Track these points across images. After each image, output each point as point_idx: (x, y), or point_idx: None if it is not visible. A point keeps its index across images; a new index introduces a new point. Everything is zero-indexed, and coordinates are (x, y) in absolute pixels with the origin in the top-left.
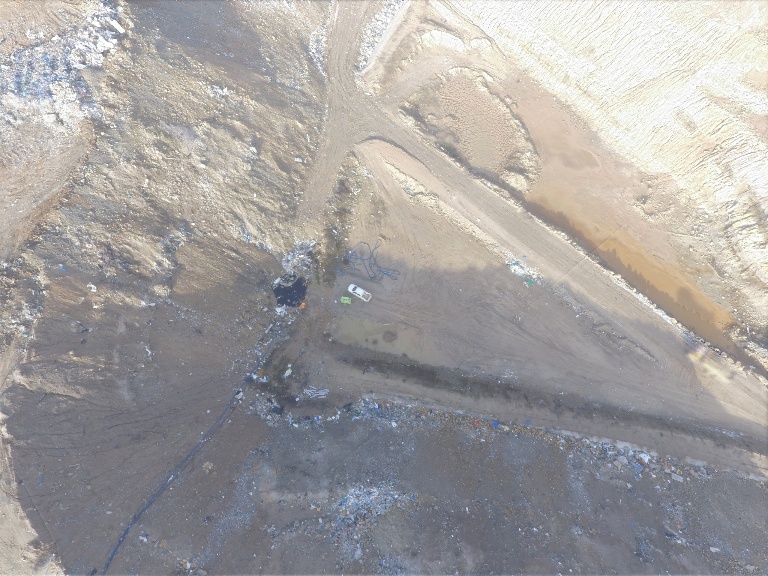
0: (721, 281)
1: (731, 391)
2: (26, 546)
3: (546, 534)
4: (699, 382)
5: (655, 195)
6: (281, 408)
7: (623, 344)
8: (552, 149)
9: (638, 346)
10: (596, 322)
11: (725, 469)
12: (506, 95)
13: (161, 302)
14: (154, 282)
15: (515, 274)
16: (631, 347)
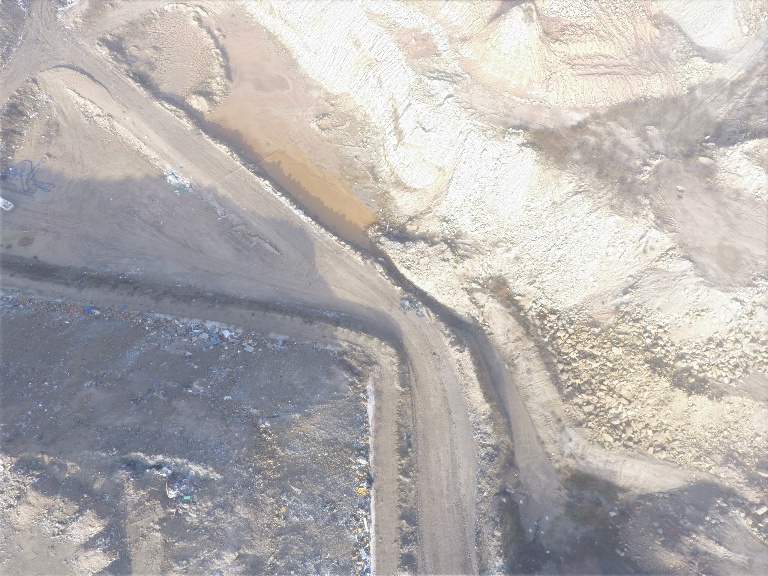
0: (374, 186)
1: (345, 278)
2: None
3: (54, 387)
4: (316, 271)
5: (335, 113)
6: None
7: (254, 241)
8: (247, 75)
9: (267, 242)
10: (235, 223)
11: (305, 341)
12: (217, 28)
13: None
14: None
15: (170, 184)
16: (261, 243)
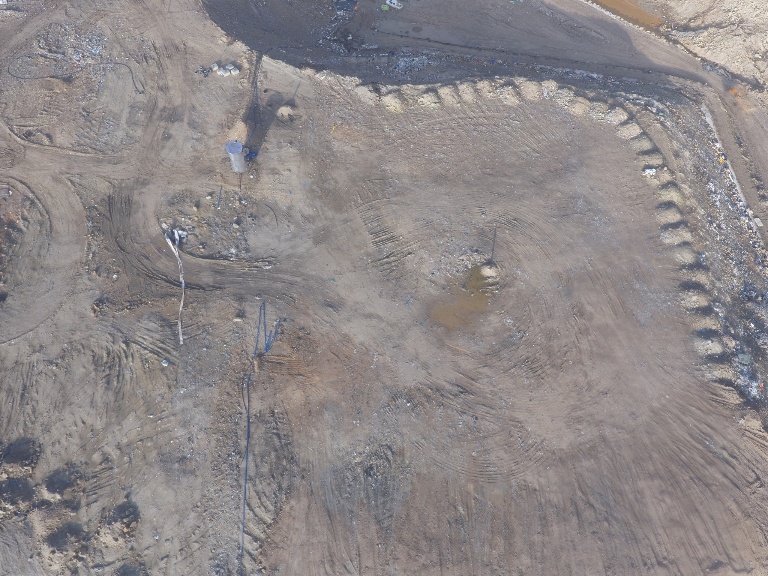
0: (654, 1)
1: (657, 52)
2: (221, 36)
3: None
4: (635, 48)
5: None
6: (348, 51)
7: (582, 31)
8: None
9: (592, 31)
10: (563, 20)
11: (649, 83)
12: None
13: None
14: None
15: None
16: (587, 32)
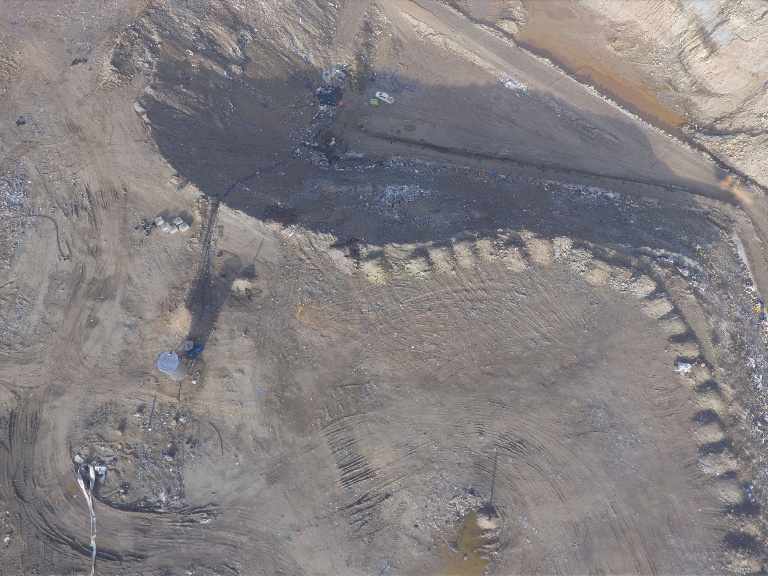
0: (676, 95)
1: (680, 162)
2: (170, 177)
3: (533, 213)
4: (655, 156)
5: (623, 37)
6: (329, 161)
7: (595, 133)
8: (538, 6)
9: (607, 133)
10: (574, 119)
11: (672, 204)
12: None
13: (236, 79)
14: (231, 63)
15: (509, 88)
16: (602, 134)
